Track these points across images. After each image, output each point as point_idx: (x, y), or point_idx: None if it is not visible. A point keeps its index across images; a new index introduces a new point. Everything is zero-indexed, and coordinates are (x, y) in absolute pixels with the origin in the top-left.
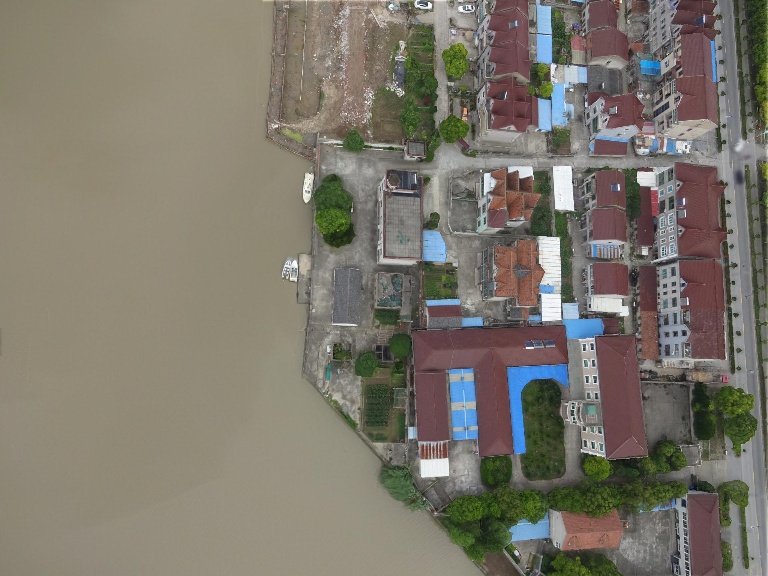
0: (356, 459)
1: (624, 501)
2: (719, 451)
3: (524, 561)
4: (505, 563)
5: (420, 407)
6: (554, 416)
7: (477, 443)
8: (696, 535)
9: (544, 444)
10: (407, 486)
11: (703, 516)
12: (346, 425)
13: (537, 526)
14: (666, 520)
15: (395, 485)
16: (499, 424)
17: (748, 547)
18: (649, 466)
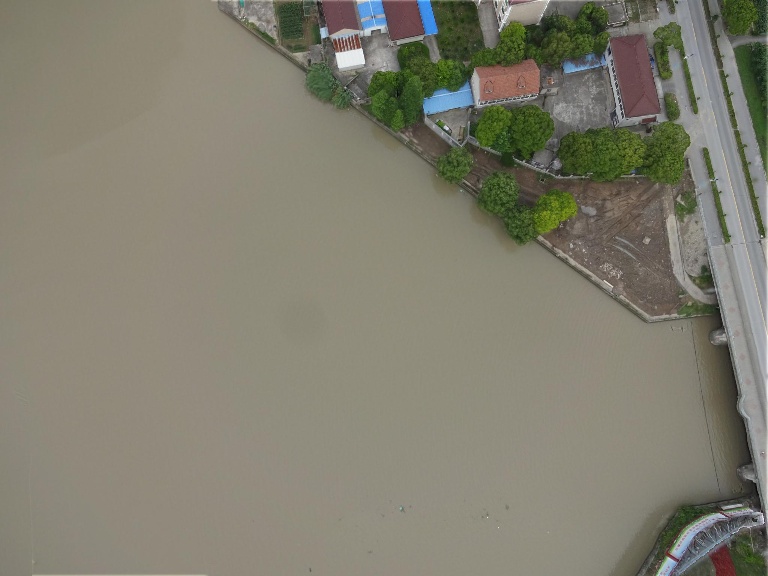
0: (282, 73)
1: (541, 53)
2: (650, 11)
3: (455, 135)
4: (438, 141)
5: (326, 6)
6: (465, 2)
7: (387, 30)
8: (623, 72)
9: (459, 30)
10: (326, 77)
11: (627, 51)
12: (268, 48)
13: (459, 95)
14: (600, 82)
15: (316, 80)
16: (403, 4)
17: (695, 95)
18: (565, 20)
